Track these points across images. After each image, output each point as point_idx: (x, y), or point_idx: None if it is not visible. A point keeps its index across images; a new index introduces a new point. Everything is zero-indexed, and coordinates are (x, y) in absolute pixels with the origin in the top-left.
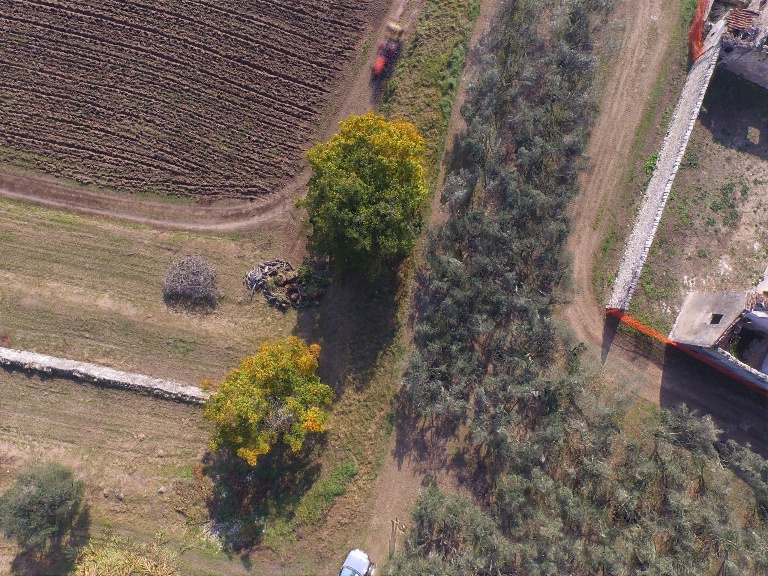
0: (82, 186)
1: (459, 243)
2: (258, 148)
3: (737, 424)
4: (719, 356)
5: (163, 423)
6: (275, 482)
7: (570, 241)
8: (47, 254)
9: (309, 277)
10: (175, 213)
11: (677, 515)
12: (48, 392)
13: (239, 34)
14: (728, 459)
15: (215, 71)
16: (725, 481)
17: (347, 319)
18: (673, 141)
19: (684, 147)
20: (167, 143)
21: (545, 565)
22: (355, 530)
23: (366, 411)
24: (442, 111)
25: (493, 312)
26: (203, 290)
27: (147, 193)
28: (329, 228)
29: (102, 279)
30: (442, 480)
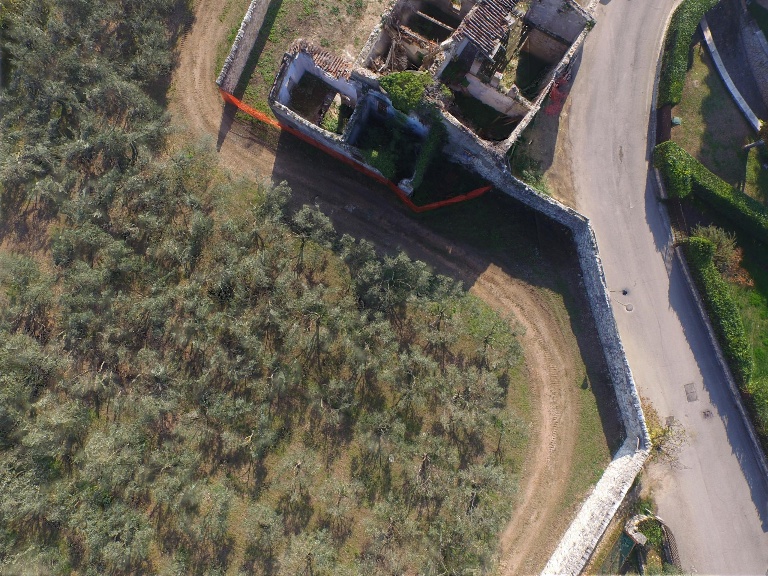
0: None
1: None
2: None
3: (342, 205)
4: None
5: None
6: None
7: (195, 32)
8: None
9: None
10: None
11: None
12: None
13: None
14: None
15: None
16: (323, 259)
17: None
18: None
19: None
20: None
21: None
22: None
23: None
24: None
25: (74, 81)
26: None
27: None
28: None
29: None
30: (39, 260)
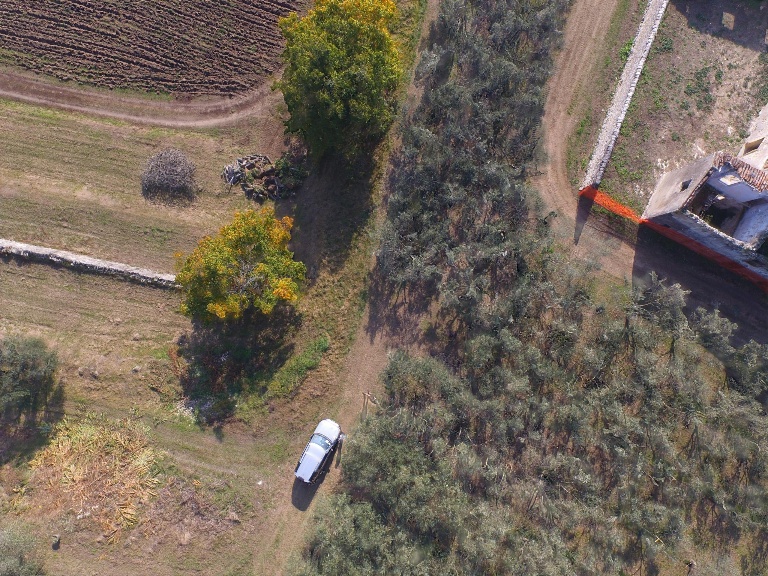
0: (62, 82)
1: (434, 126)
2: (237, 45)
3: (708, 301)
4: (688, 222)
5: (139, 308)
6: (249, 361)
7: (545, 125)
8: (26, 148)
9: (287, 170)
10: (154, 110)
11: (647, 388)
12: (25, 277)
13: None
14: (696, 325)
15: None
16: (695, 356)
17: (323, 207)
18: (647, 23)
19: (657, 24)
20: (147, 40)
21: (512, 421)
22: (327, 403)
23: (340, 290)
24: None
25: (464, 182)
26: (180, 180)
27: (127, 90)
28: (301, 96)
29: (81, 172)
30: (414, 354)
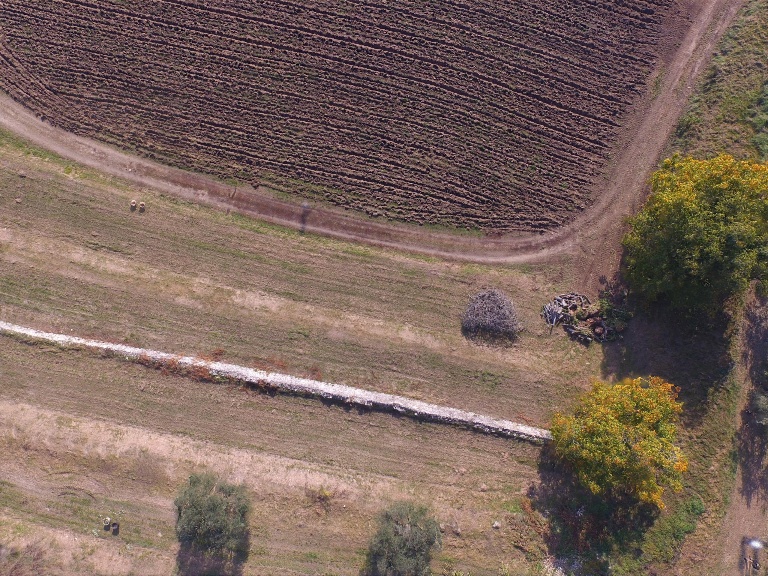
0: (371, 218)
1: None
2: (548, 181)
3: None
4: None
5: (482, 457)
6: (610, 518)
7: None
8: (343, 286)
9: (609, 311)
10: (464, 245)
11: None
12: (366, 426)
13: (529, 68)
14: None
15: (505, 104)
16: None
17: (661, 354)
18: None
19: None
20: (457, 176)
21: None
22: (707, 568)
23: (702, 448)
24: (758, 148)
25: None
26: (511, 324)
27: (436, 225)
28: (700, 270)
29: (399, 311)
30: None
